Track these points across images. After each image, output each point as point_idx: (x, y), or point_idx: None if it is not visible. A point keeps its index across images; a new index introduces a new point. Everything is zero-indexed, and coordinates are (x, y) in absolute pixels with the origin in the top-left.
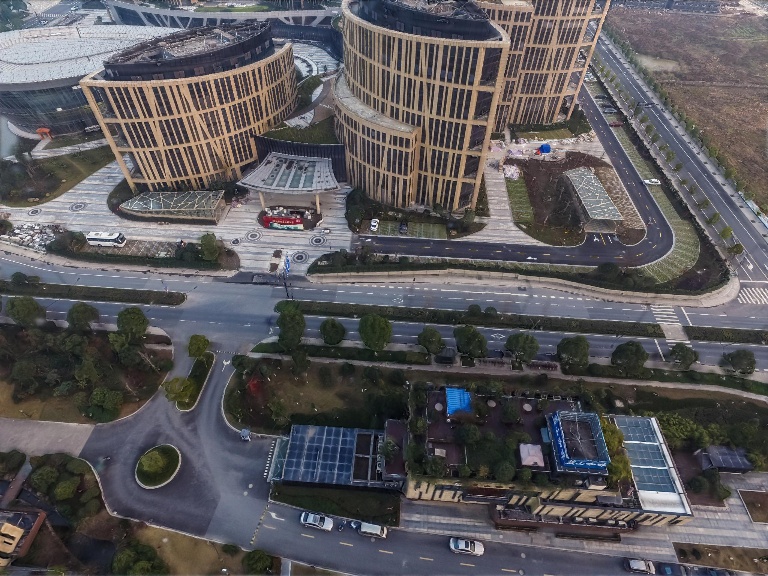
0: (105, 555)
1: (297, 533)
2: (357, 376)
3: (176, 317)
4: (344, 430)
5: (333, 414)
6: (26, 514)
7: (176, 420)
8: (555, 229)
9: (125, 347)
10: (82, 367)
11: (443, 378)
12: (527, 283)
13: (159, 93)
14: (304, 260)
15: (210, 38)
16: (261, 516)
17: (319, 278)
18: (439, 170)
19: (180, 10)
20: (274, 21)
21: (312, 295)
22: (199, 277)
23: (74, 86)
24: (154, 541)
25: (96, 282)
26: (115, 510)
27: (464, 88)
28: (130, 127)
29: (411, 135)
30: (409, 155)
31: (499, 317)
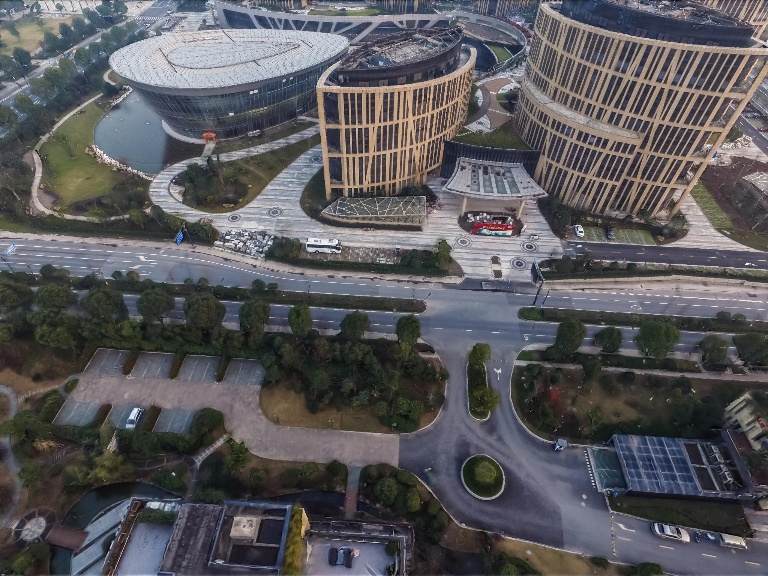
0: (473, 568)
1: (655, 544)
2: (637, 384)
3: (425, 324)
4: (665, 440)
5: (644, 423)
6: (396, 527)
7: (477, 429)
8: (759, 235)
9: (412, 356)
10: (391, 376)
11: (742, 386)
12: (755, 289)
13: (388, 99)
14: (525, 266)
15: (416, 43)
16: (610, 527)
17: (547, 285)
18: (651, 176)
19: (296, 13)
20: (387, 25)
21: (549, 302)
22: (428, 284)
23: (251, 91)
24: (519, 553)
25: (329, 289)
26: (462, 522)
27: (712, 95)
28: (349, 133)
29: (640, 141)
30: (629, 161)
31: (748, 324)
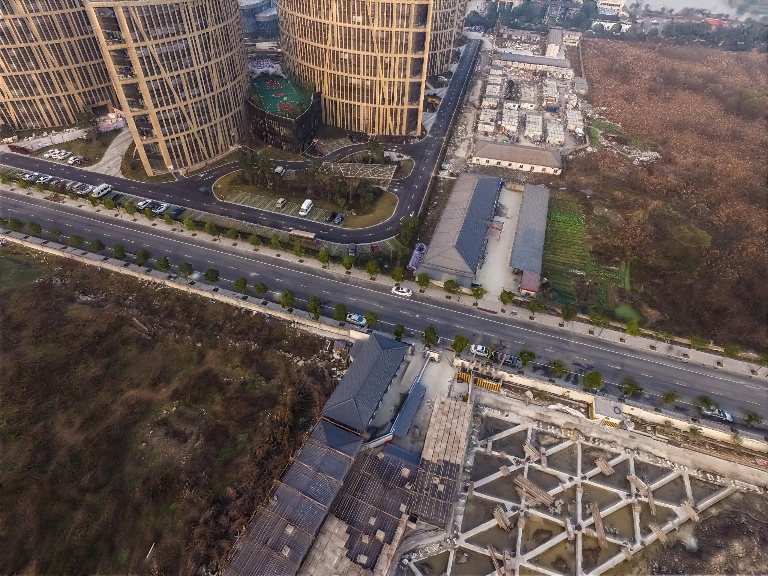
0: None
1: None
2: None
3: None
4: None
5: None
6: None
7: None
8: None
9: None
10: None
11: None
12: None
13: None
14: None
15: None
16: None
17: None
18: None
19: None
20: None
21: None
22: None
23: None
24: None
25: None
26: None
27: None
28: None
29: None
30: None
31: None
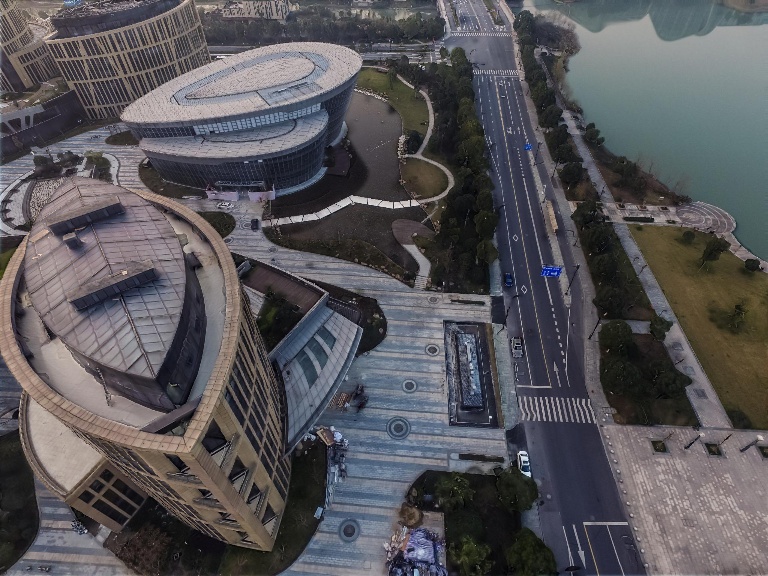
0: None
1: None
2: None
3: None
4: None
5: None
6: None
7: None
8: None
9: None
10: None
11: None
12: None
13: None
14: None
15: None
16: None
17: None
18: None
19: None
20: None
21: None
22: None
23: None
24: None
25: None
26: None
27: None
28: None
29: None
30: None
31: None
